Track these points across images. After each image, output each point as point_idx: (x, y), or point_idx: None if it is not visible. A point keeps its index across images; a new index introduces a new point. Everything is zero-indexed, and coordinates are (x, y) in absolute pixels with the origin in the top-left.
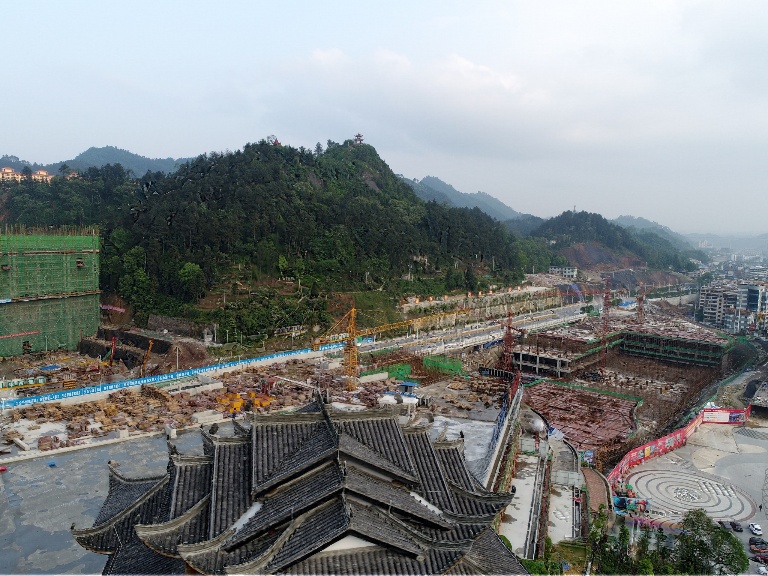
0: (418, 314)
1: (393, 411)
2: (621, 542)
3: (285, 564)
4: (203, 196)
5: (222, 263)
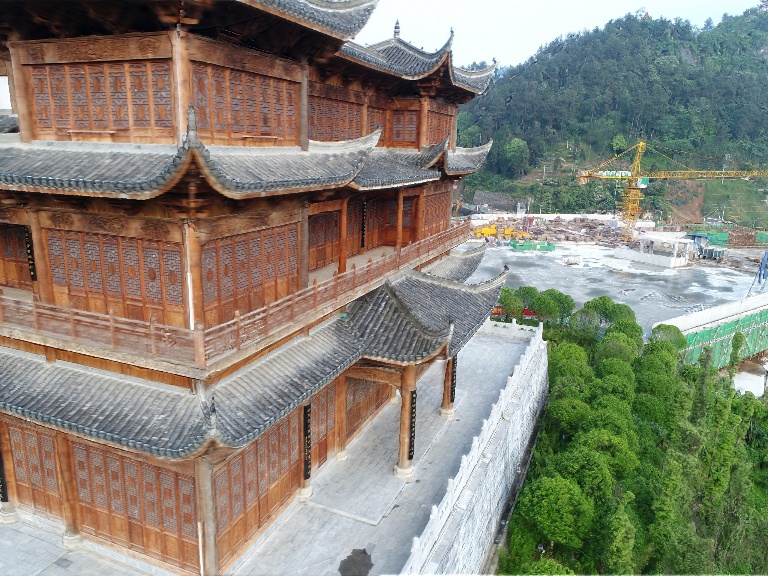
0: (747, 165)
1: None
2: None
3: None
4: (546, 75)
5: (549, 139)
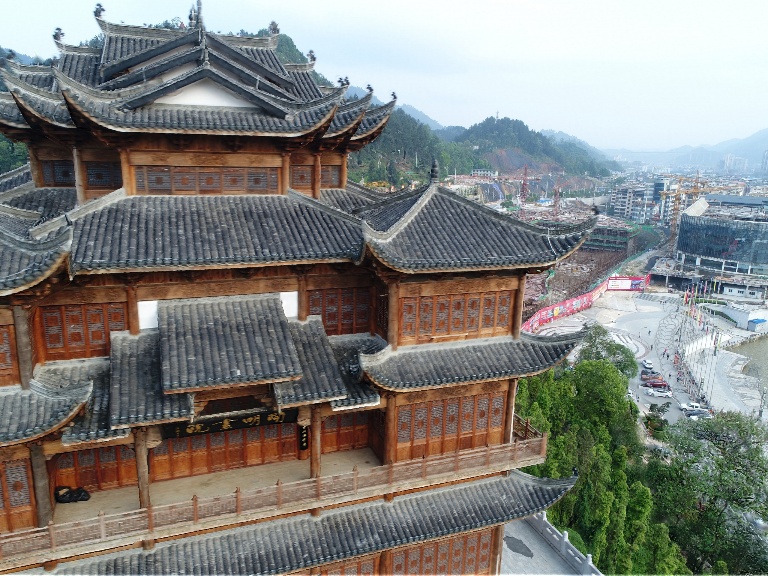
0: None
1: (269, 41)
2: None
3: (132, 99)
4: None
5: None
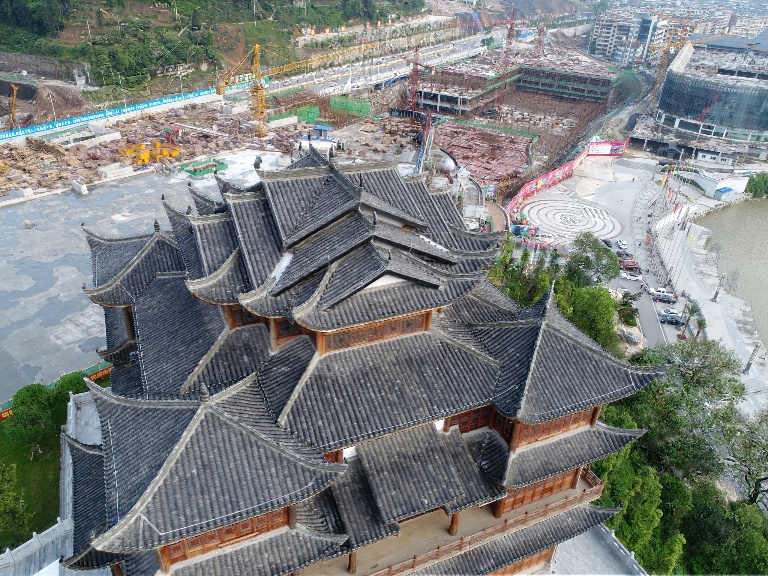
0: (325, 50)
1: (393, 162)
2: (522, 262)
3: (334, 302)
4: None
5: None
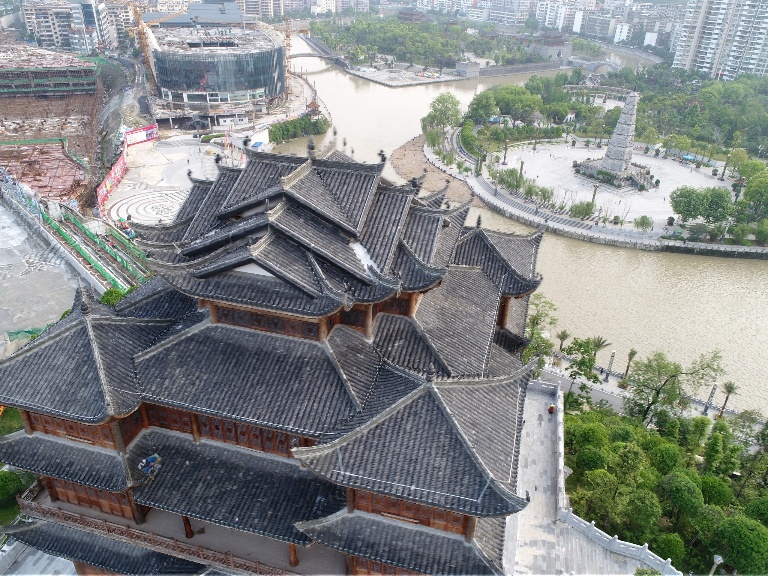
0: None
1: None
2: None
3: None
4: None
5: None
